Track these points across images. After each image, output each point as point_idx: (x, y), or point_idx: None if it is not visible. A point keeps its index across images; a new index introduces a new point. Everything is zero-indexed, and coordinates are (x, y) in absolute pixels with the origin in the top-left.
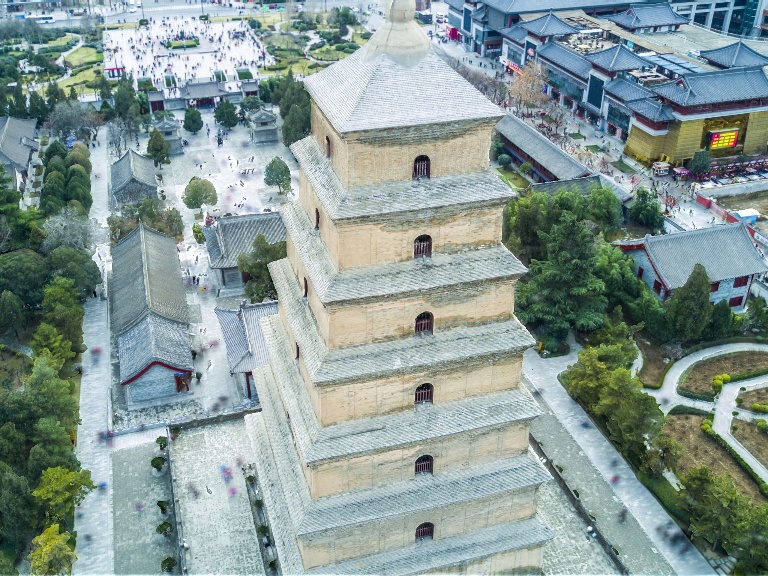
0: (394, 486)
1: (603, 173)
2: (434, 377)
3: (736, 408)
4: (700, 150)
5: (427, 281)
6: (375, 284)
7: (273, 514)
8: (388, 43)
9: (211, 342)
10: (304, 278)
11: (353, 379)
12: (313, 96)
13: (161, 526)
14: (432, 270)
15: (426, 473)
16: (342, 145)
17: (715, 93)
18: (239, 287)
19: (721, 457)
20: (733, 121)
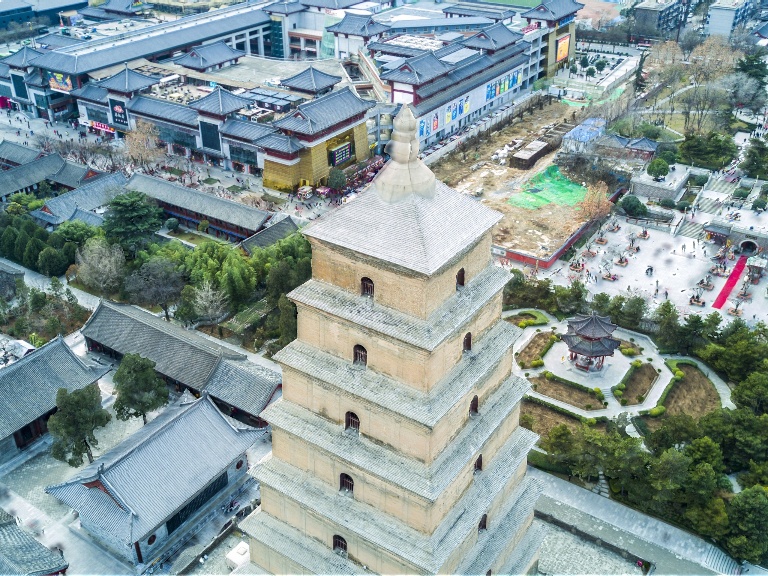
0: (470, 555)
1: (273, 211)
2: (483, 447)
3: (522, 370)
4: (329, 168)
5: (479, 371)
6: (453, 391)
7: None
8: (413, 182)
9: (39, 528)
10: (346, 413)
11: None
12: (345, 245)
13: None
14: (477, 360)
15: (481, 531)
16: (416, 283)
17: (328, 118)
18: (16, 455)
19: (542, 412)
20: (344, 137)
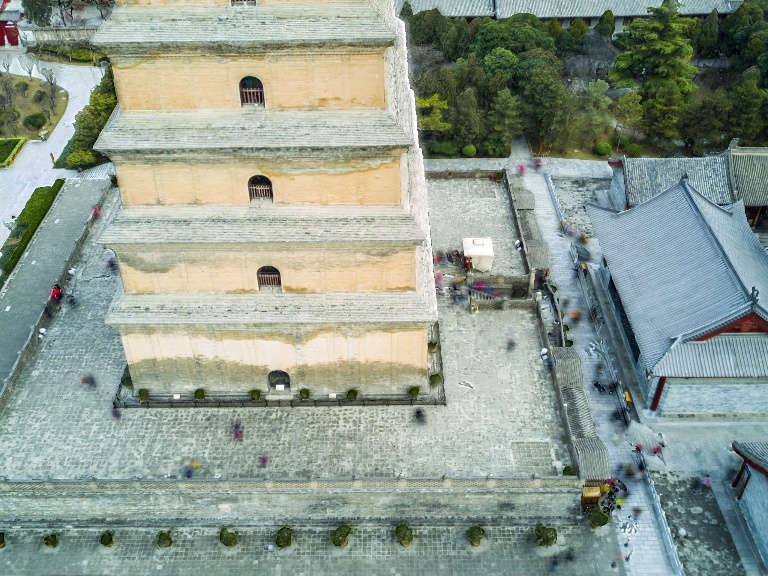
0: None
1: None
2: None
3: None
4: None
5: None
6: None
7: None
8: None
9: None
10: None
11: None
12: None
13: None
14: None
15: None
16: None
17: None
18: None
19: None
20: None
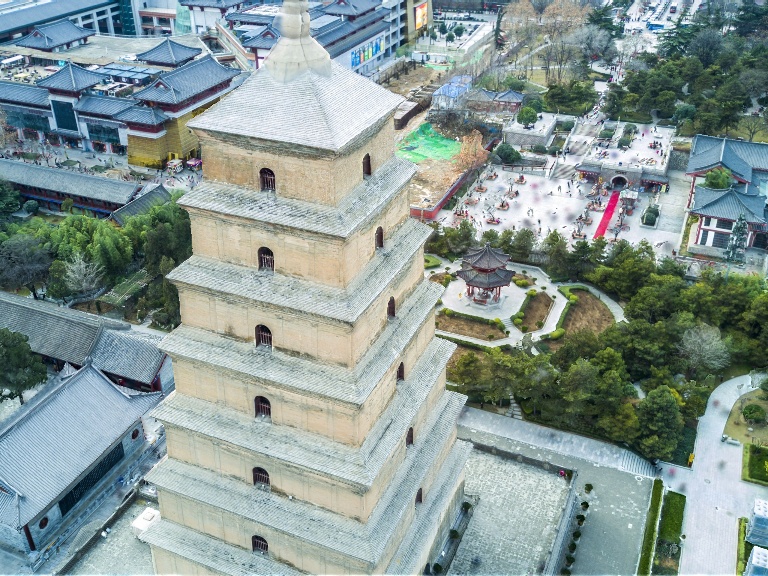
0: (400, 471)
1: None
2: (404, 354)
3: None
4: None
5: (394, 267)
6: (370, 287)
7: None
8: (307, 58)
9: None
10: (256, 327)
11: None
12: (239, 132)
13: None
14: (391, 257)
15: (409, 446)
16: (322, 165)
17: (192, 86)
18: None
19: None
20: None
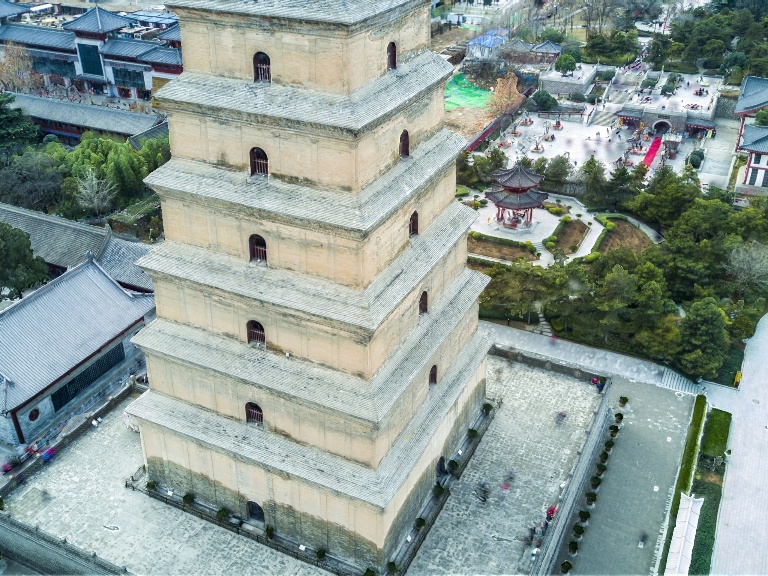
0: (411, 337)
1: None
2: (418, 202)
3: None
4: None
5: (408, 90)
6: (379, 102)
7: (277, 459)
8: None
9: None
10: (250, 150)
11: (382, 219)
12: None
13: None
14: (405, 80)
15: (422, 314)
16: None
17: None
18: None
19: (473, 267)
20: None
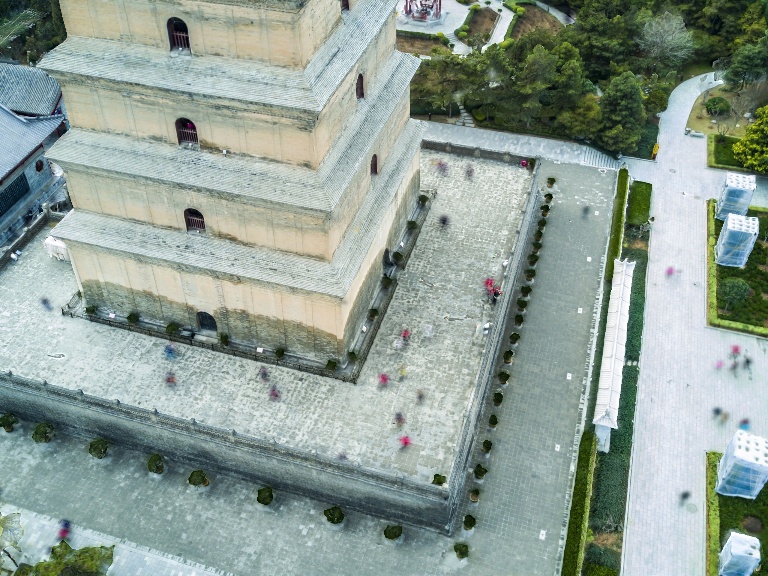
0: (351, 123)
1: None
2: None
3: None
4: None
5: None
6: None
7: (225, 263)
8: None
9: None
10: None
11: None
12: None
13: (39, 432)
14: None
15: (359, 100)
16: None
17: None
18: None
19: None
20: None
